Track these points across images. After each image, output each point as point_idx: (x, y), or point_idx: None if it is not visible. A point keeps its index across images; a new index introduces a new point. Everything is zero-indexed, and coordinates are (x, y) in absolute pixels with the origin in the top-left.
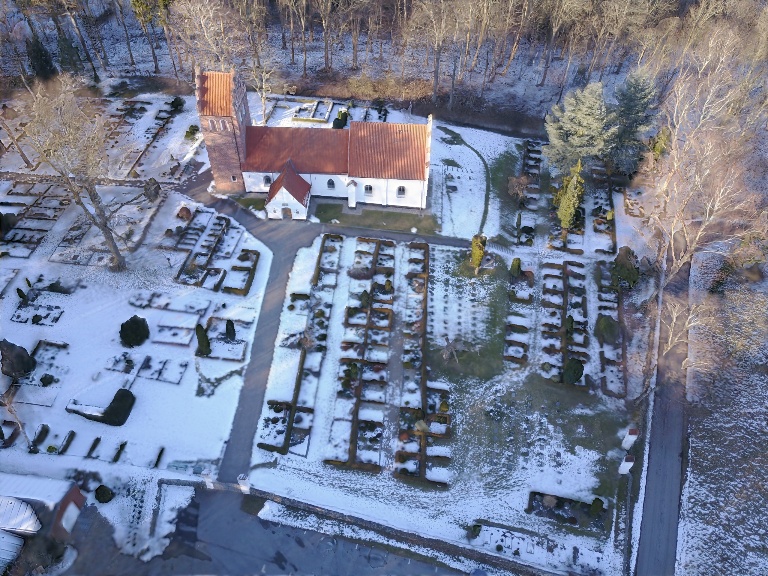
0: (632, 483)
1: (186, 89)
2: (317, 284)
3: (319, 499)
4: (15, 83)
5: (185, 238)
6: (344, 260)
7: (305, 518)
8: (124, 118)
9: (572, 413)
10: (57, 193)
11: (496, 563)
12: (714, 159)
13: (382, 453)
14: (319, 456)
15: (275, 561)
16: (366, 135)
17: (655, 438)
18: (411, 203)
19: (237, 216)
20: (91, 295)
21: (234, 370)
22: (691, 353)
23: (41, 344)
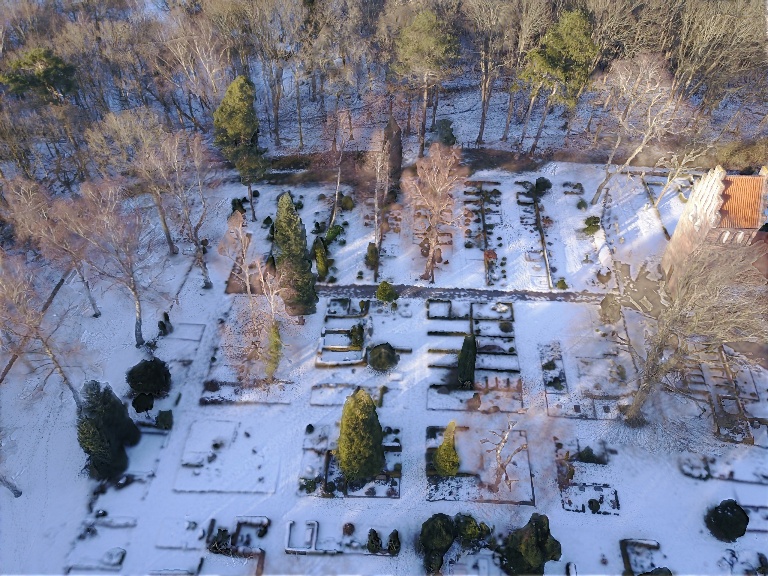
0: None
1: (528, 163)
2: None
3: None
4: (326, 162)
5: None
6: None
7: None
8: (483, 204)
9: None
10: (485, 314)
11: None
12: None
13: None
14: None
15: None
16: None
17: None
18: None
19: None
20: (630, 464)
21: None
22: None
23: (627, 545)
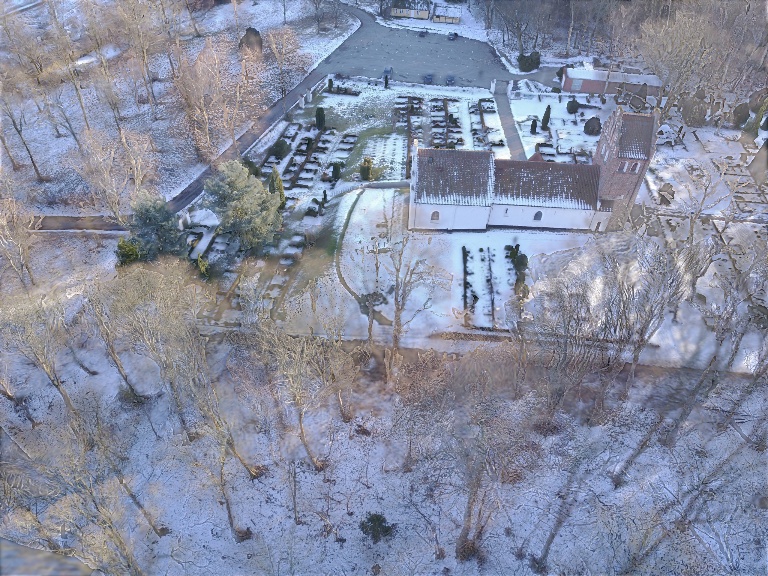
0: None
1: None
2: None
3: (458, 93)
4: None
5: None
6: None
7: None
8: None
9: (325, 118)
10: (759, 208)
11: None
12: None
13: (430, 105)
14: (462, 103)
15: None
16: None
17: None
18: None
19: None
20: None
21: None
22: None
23: None
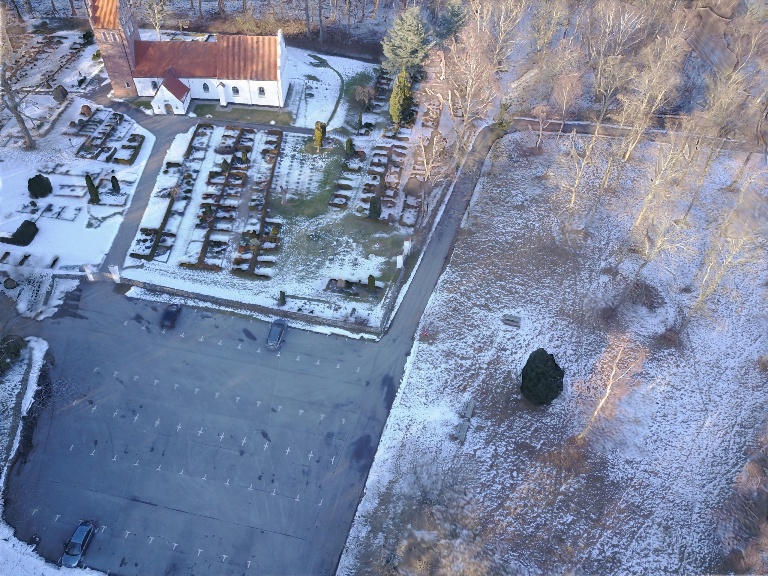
0: (405, 274)
1: None
2: (189, 157)
3: (172, 286)
4: None
5: (86, 128)
6: (213, 142)
7: (160, 296)
8: (43, 48)
9: (372, 236)
10: None
11: (295, 317)
12: (474, 47)
13: (224, 260)
14: (176, 262)
15: (135, 319)
16: (230, 45)
17: (430, 249)
18: (271, 102)
19: (130, 113)
20: (7, 166)
21: (117, 212)
22: (473, 200)
23: None
